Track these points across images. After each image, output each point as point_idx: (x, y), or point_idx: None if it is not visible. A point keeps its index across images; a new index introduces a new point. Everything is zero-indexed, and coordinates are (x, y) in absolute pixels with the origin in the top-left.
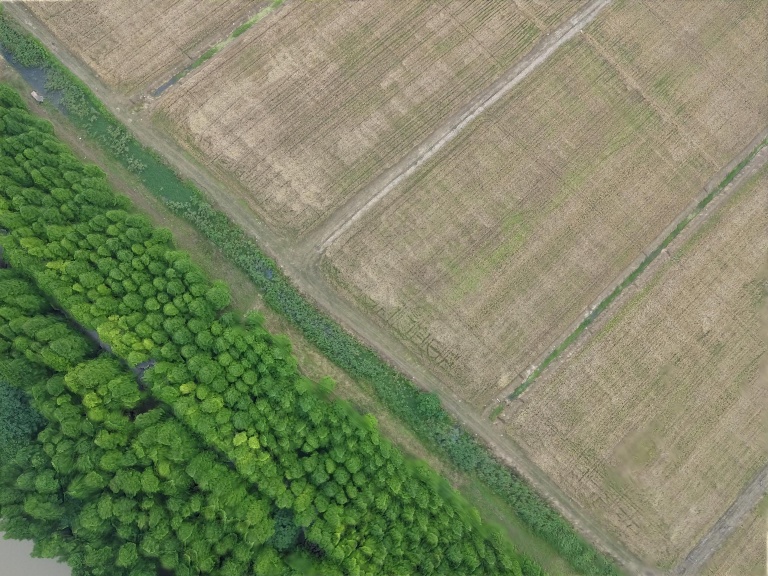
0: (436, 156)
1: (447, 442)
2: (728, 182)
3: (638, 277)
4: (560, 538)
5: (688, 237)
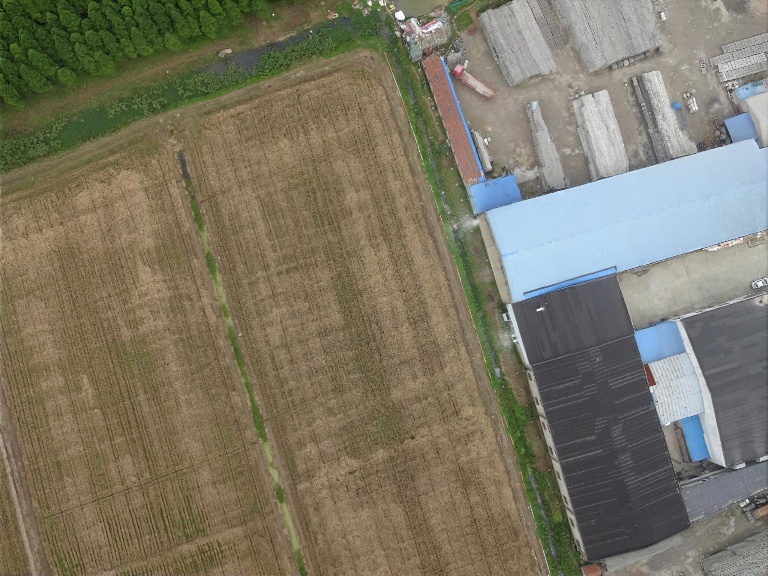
0: None
1: None
2: None
3: None
4: None
5: None
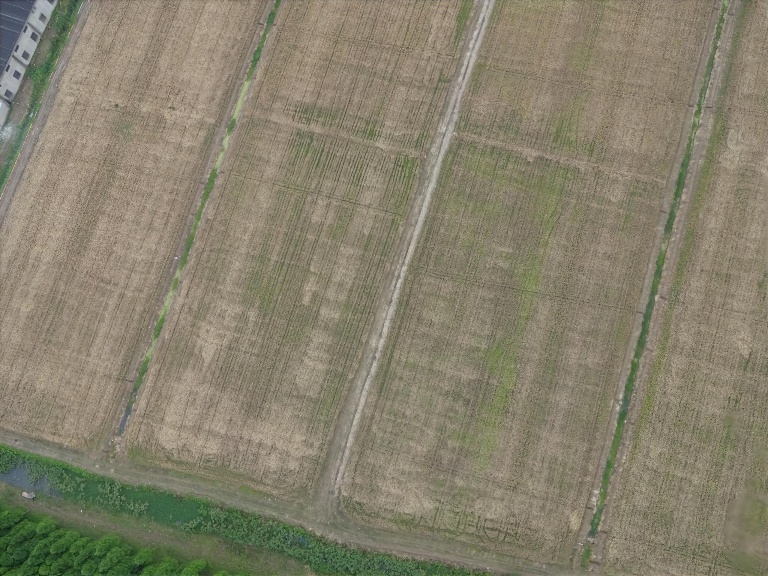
0: (389, 339)
1: None
2: (681, 189)
3: (647, 339)
4: None
5: (673, 270)
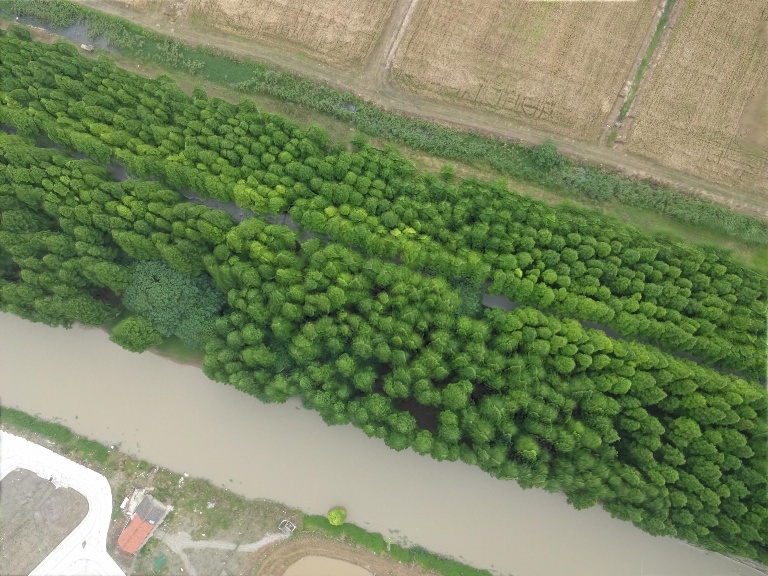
0: None
1: (577, 182)
2: None
3: None
4: (721, 218)
5: None
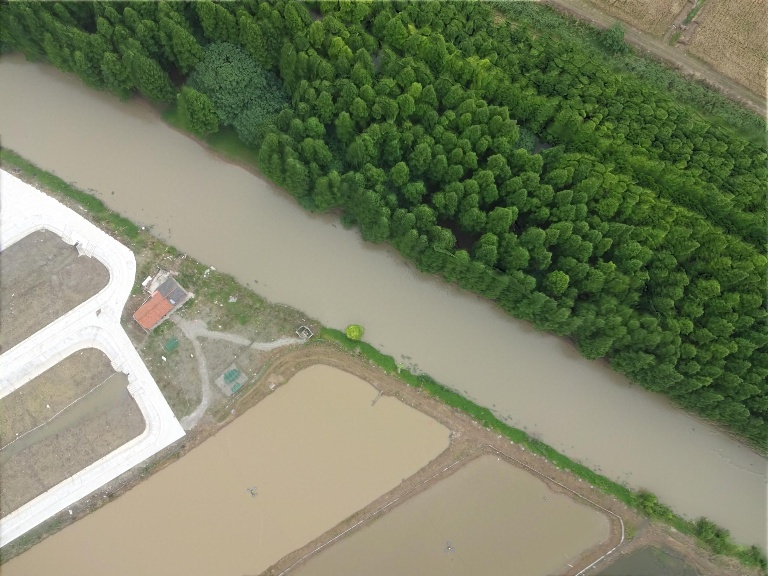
0: None
1: (637, 69)
2: None
3: None
4: (763, 126)
5: None
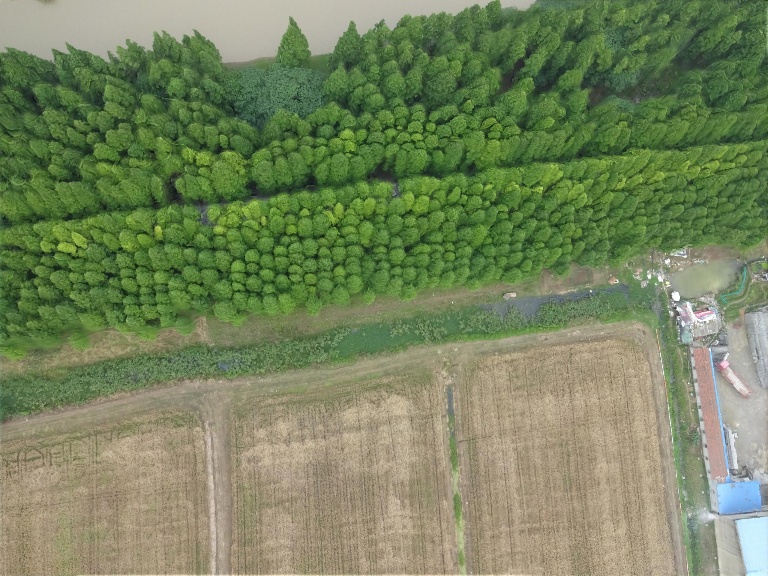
0: None
1: None
2: None
3: None
4: None
5: None
